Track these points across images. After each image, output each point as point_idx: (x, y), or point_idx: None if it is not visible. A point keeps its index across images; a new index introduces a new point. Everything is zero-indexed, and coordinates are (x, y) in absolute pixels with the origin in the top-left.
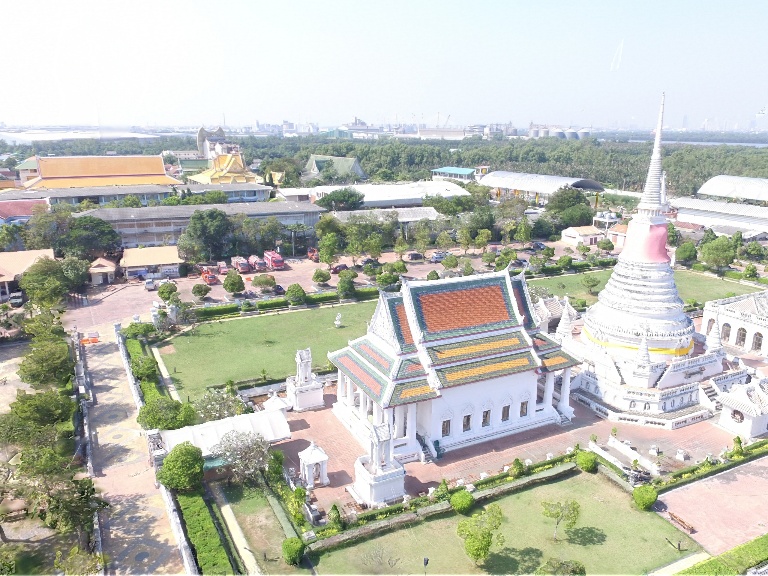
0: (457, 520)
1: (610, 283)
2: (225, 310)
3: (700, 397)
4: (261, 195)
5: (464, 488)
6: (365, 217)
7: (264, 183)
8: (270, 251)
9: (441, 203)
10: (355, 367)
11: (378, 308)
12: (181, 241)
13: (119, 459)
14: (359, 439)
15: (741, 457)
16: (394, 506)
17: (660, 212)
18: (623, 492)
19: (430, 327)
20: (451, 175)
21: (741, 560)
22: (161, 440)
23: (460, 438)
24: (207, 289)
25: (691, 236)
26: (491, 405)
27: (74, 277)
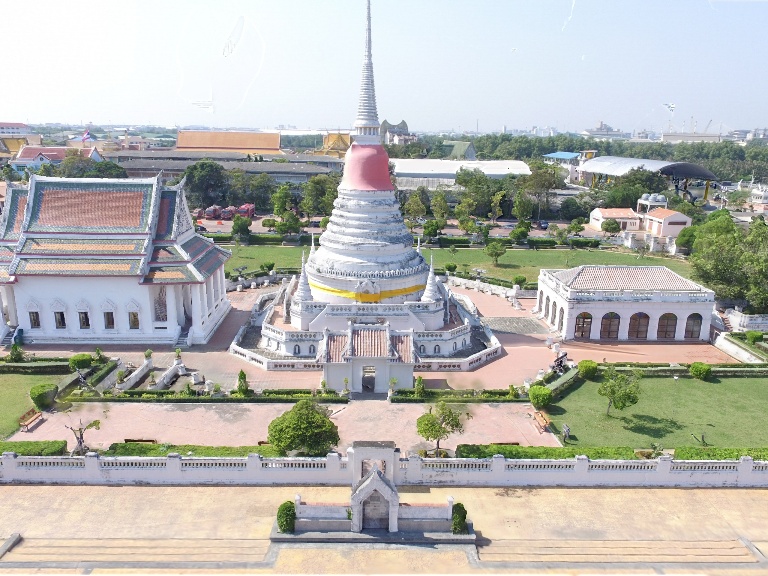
0: None
1: None
2: None
3: None
4: (333, 167)
5: None
6: None
7: None
8: (250, 204)
9: (471, 177)
10: None
11: None
12: None
13: None
14: None
15: (242, 396)
16: None
17: None
18: None
19: (42, 220)
20: None
21: None
22: None
23: (52, 334)
24: None
25: None
26: (86, 307)
27: None
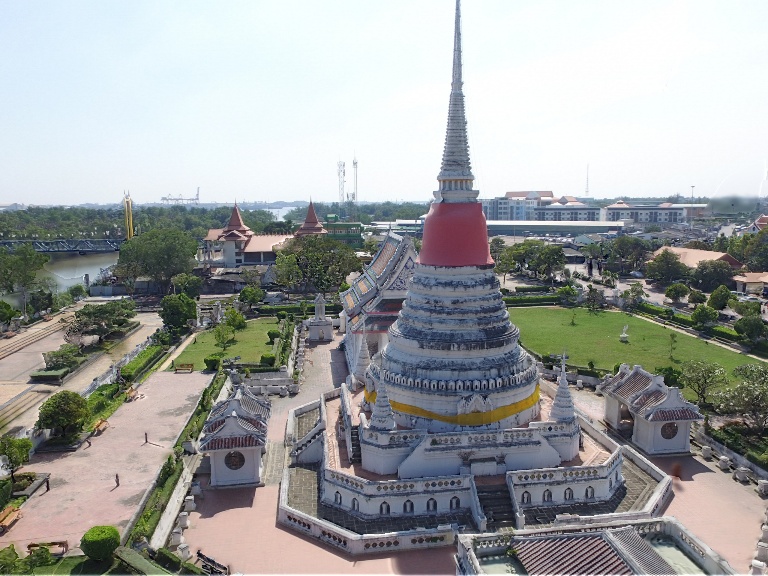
0: None
1: None
2: None
3: None
4: None
5: None
6: None
7: None
8: None
9: None
10: None
11: None
12: None
13: None
14: None
15: None
16: None
17: None
18: None
19: None
20: None
21: (137, 360)
22: None
23: None
24: None
25: None
26: None
27: (695, 274)
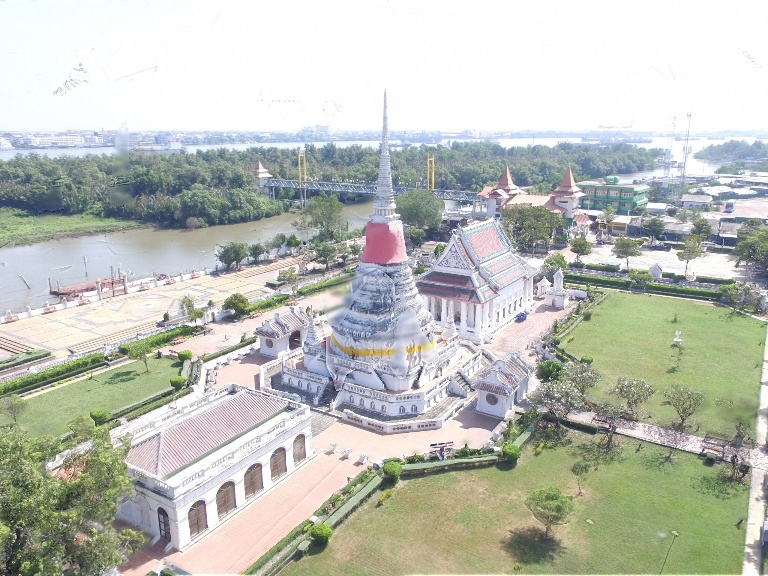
0: None
1: None
2: None
3: None
4: None
5: None
6: None
7: None
8: None
9: None
10: None
11: None
12: None
13: None
14: None
15: None
16: None
17: None
18: None
19: None
20: None
21: None
22: None
23: None
24: None
25: None
26: None
27: None
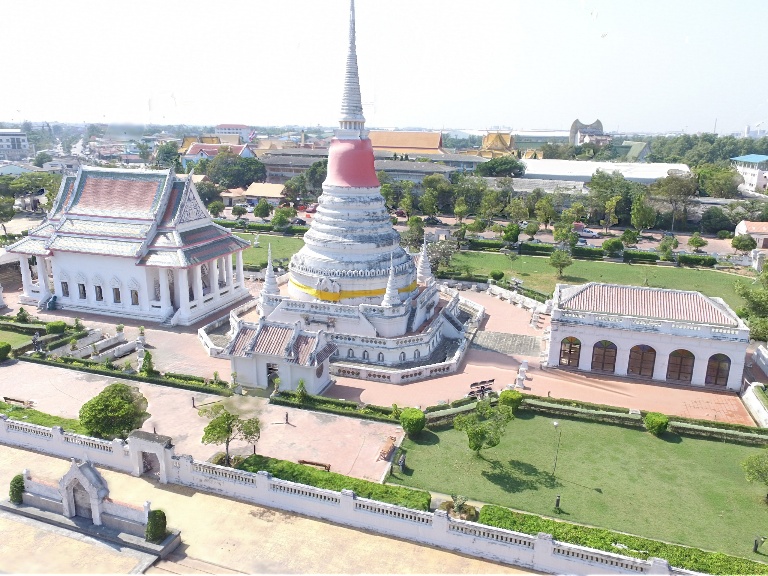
0: None
1: None
2: (225, 224)
3: None
4: None
5: None
6: (471, 180)
7: None
8: None
9: (606, 180)
10: None
11: None
12: None
13: None
14: None
15: (146, 375)
16: None
17: None
18: None
19: (81, 204)
20: (745, 164)
21: None
22: None
23: (77, 302)
24: (243, 211)
25: None
26: (100, 281)
27: None
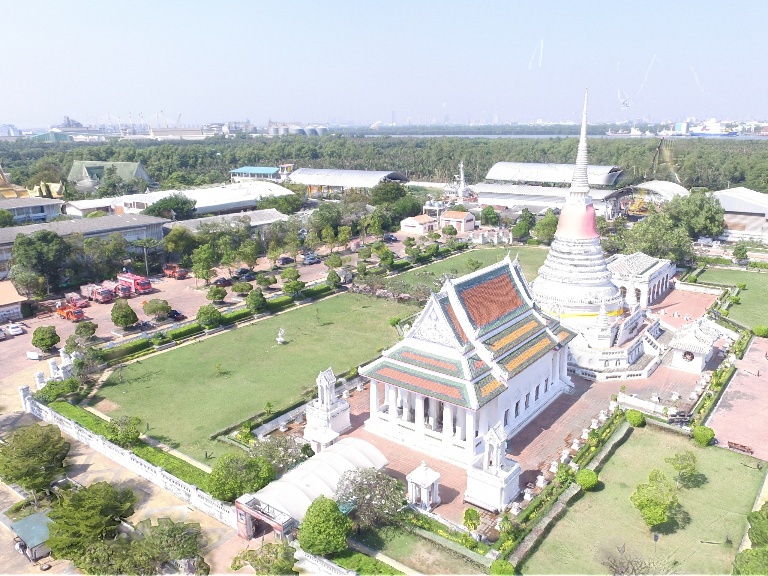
0: (591, 498)
1: (554, 261)
2: (135, 347)
3: (645, 347)
4: (51, 211)
5: (570, 468)
6: (218, 224)
7: (40, 196)
8: (124, 273)
9: (279, 204)
10: (407, 377)
11: (426, 311)
12: (15, 274)
13: (198, 545)
14: (422, 450)
15: (719, 387)
16: (536, 502)
17: (464, 198)
18: (678, 436)
19: (477, 322)
20: (253, 175)
21: None
22: (261, 505)
23: (514, 425)
24: (93, 327)
25: (508, 216)
26: None
27: None
